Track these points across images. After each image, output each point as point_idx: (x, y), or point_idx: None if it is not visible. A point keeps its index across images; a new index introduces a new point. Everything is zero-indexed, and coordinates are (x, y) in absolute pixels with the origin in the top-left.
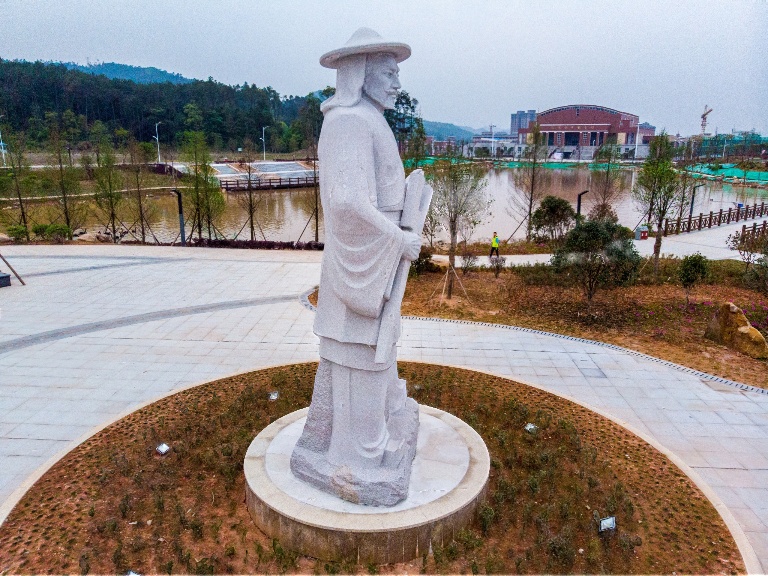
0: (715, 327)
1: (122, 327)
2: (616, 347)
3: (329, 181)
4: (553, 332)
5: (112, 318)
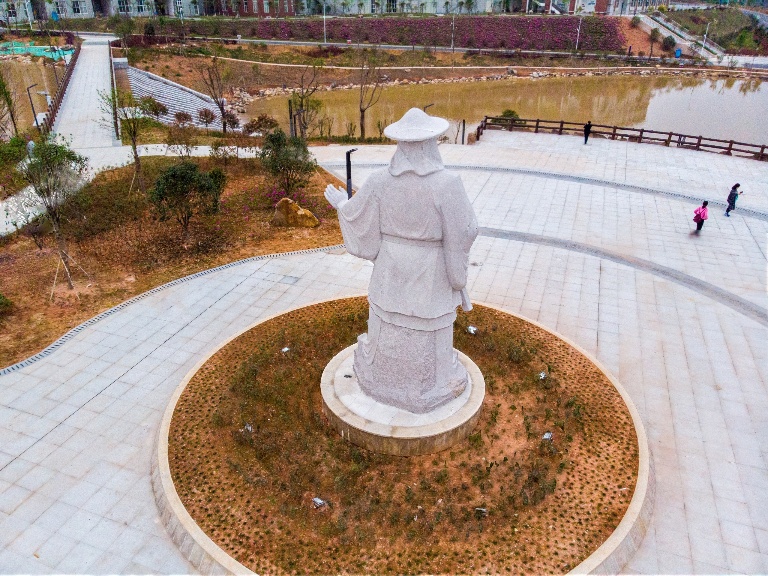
0: (281, 217)
1: None
2: (258, 258)
3: (464, 220)
4: (205, 269)
5: None
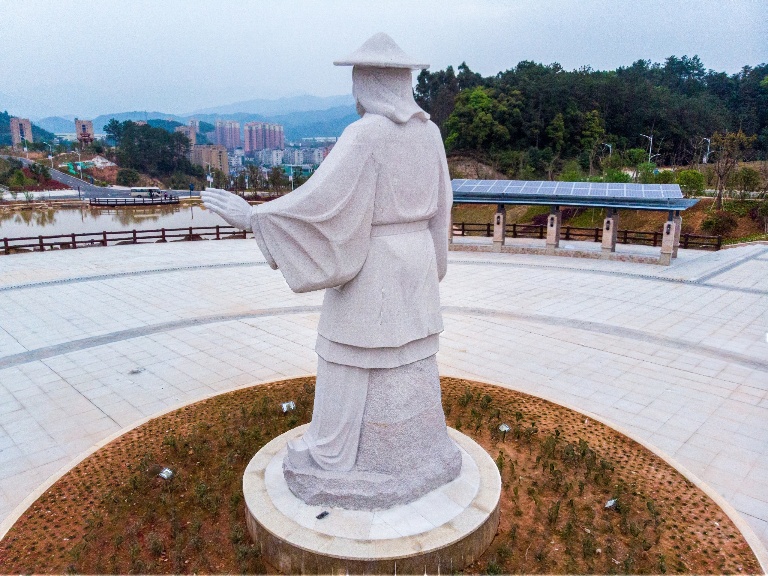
0: None
1: None
2: None
3: None
4: None
5: None
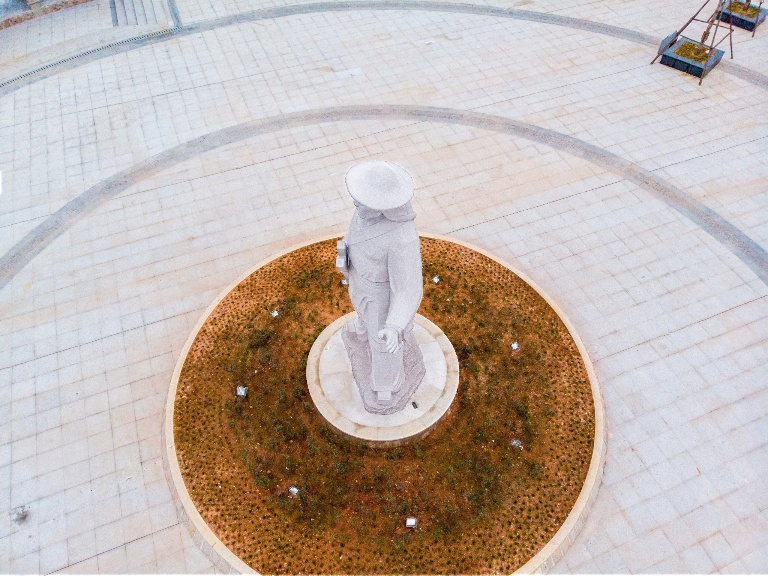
0: None
1: None
2: None
3: None
4: None
5: None
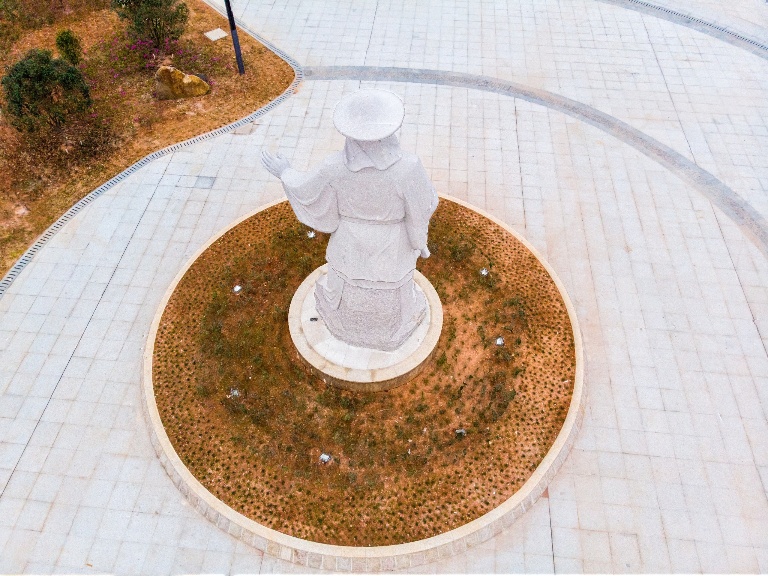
0: (165, 89)
1: None
2: (158, 154)
3: None
4: (103, 181)
5: None
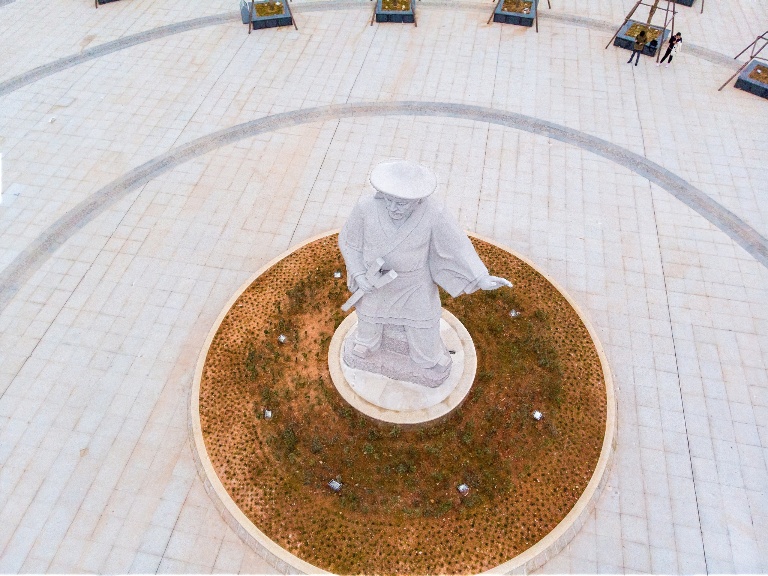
0: None
1: (682, 203)
2: None
3: None
4: None
5: (705, 191)
